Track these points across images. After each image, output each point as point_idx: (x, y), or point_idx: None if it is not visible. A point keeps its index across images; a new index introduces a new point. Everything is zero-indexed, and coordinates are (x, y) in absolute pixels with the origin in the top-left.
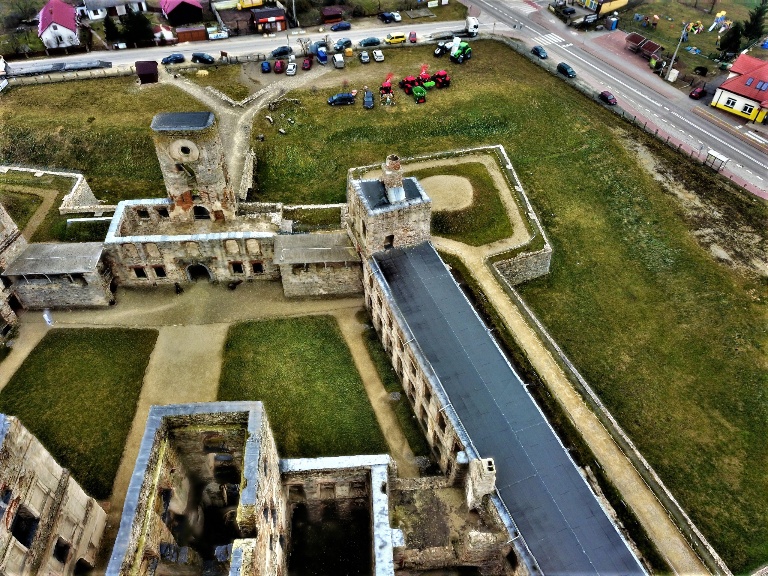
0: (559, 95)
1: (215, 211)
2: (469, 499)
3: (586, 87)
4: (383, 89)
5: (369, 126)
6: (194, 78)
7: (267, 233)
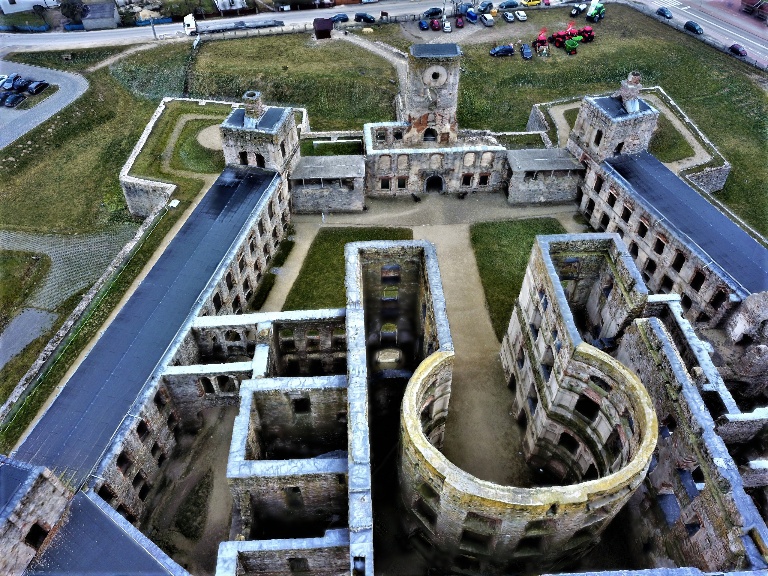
0: (693, 48)
1: (443, 133)
2: (738, 332)
3: (715, 42)
4: (539, 42)
5: (532, 73)
6: (362, 34)
7: (501, 147)
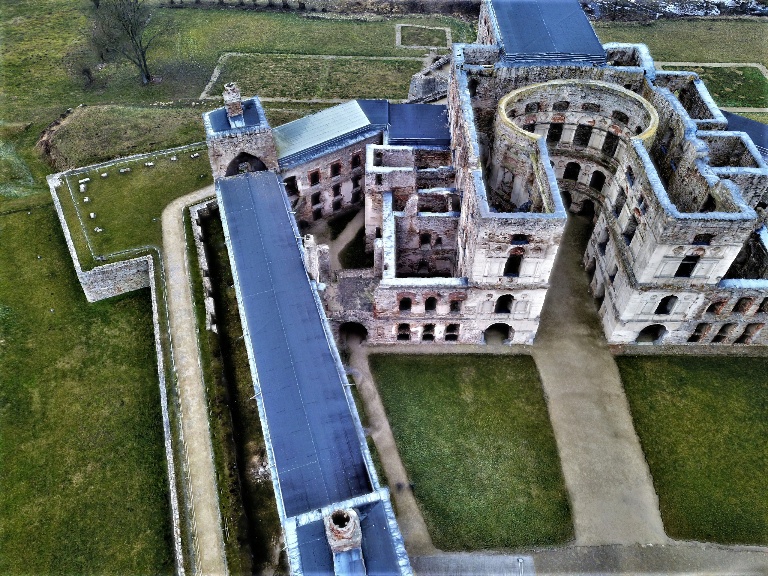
0: None
1: None
2: None
3: None
4: None
5: None
6: None
7: None
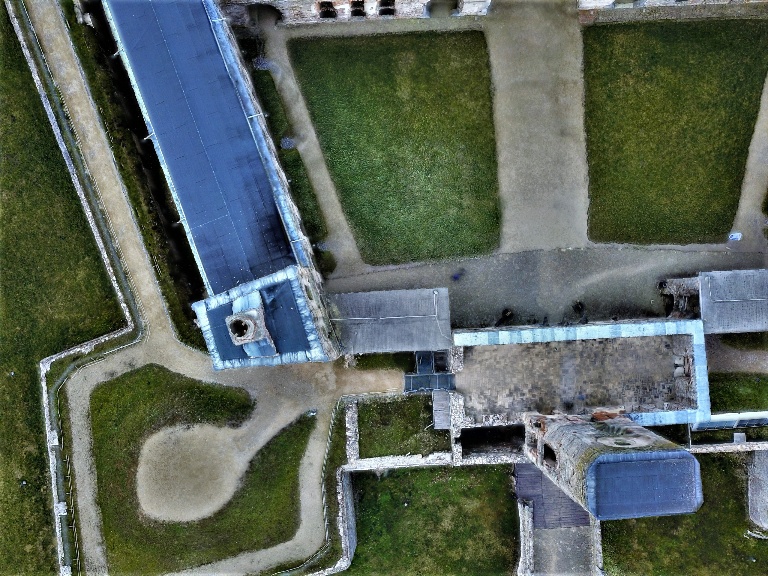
0: None
1: None
2: None
3: None
4: None
5: None
6: None
7: (463, 342)
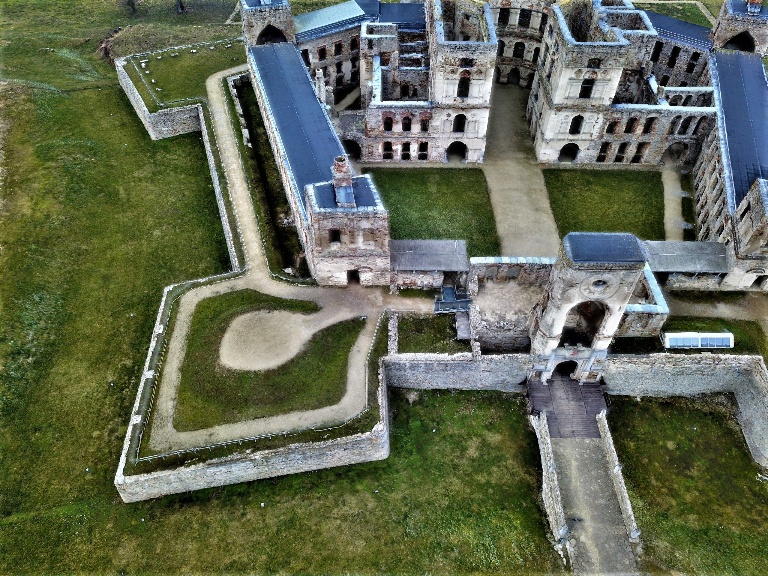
0: None
1: None
2: None
3: None
4: None
5: None
6: None
7: (477, 260)
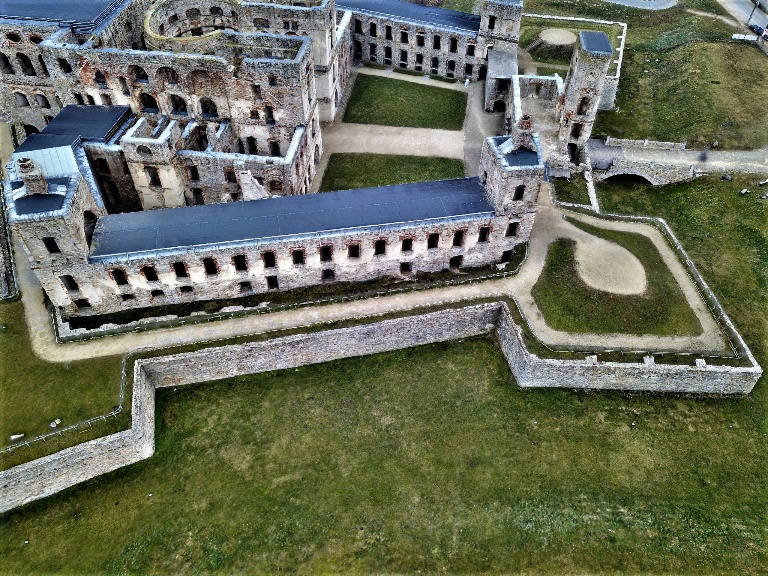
0: None
1: None
2: None
3: None
4: None
5: None
6: None
7: None
